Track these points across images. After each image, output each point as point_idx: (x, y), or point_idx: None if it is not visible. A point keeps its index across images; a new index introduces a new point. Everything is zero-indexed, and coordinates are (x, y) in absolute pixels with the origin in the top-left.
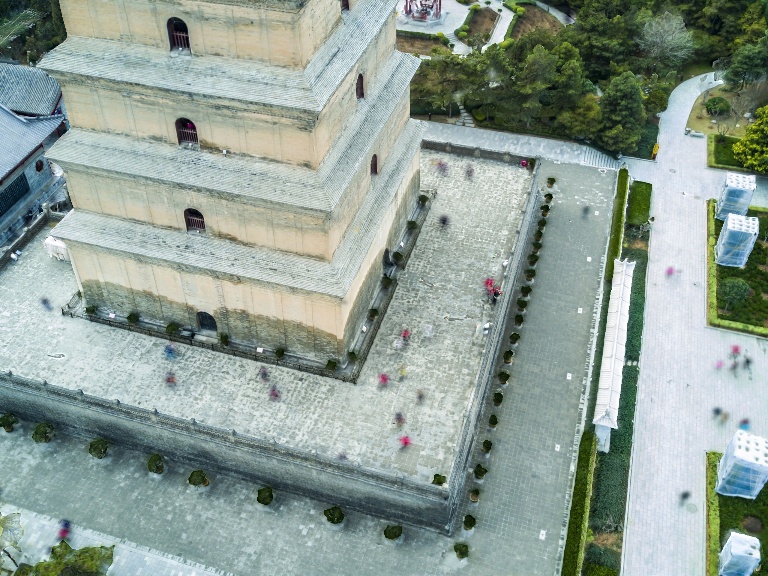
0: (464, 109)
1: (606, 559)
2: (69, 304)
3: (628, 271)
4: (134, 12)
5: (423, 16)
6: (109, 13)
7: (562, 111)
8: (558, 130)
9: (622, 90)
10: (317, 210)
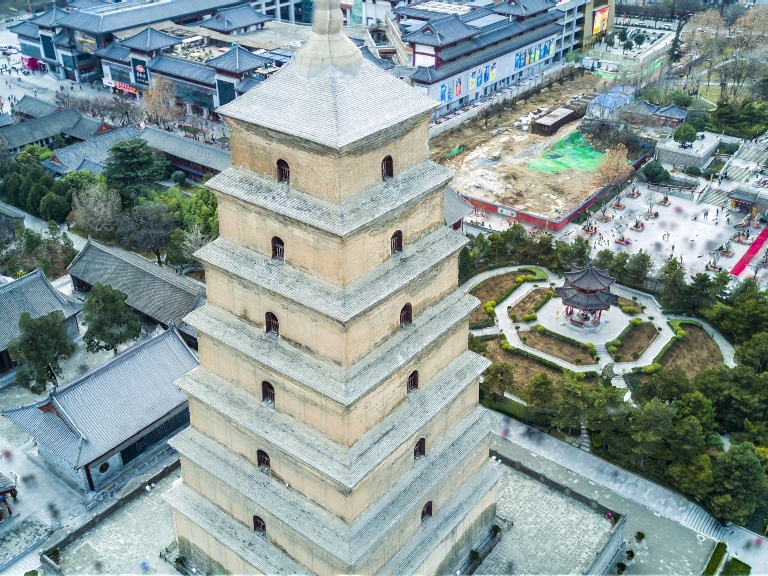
0: (586, 429)
1: None
2: (168, 548)
3: None
4: (242, 368)
5: (580, 322)
6: (227, 363)
7: (676, 461)
8: (669, 479)
9: (738, 460)
10: (341, 559)
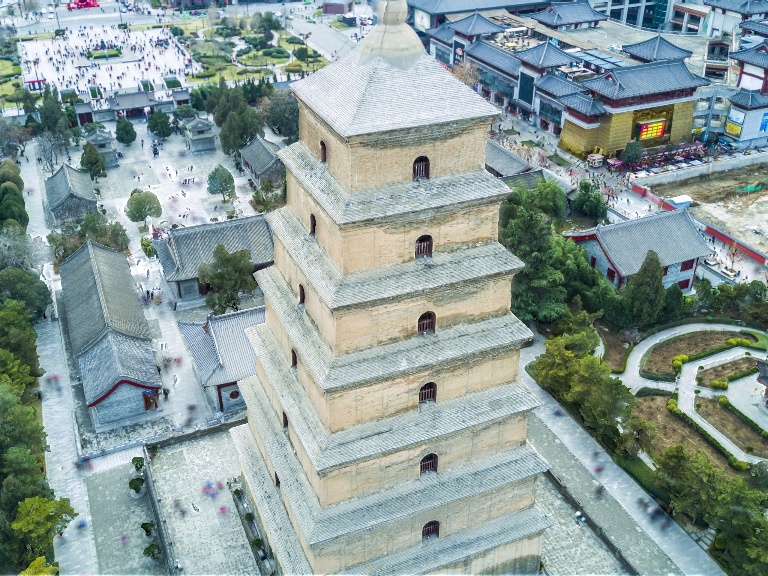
0: None
1: None
2: (237, 478)
3: None
4: None
5: None
6: None
7: None
8: None
9: None
10: None
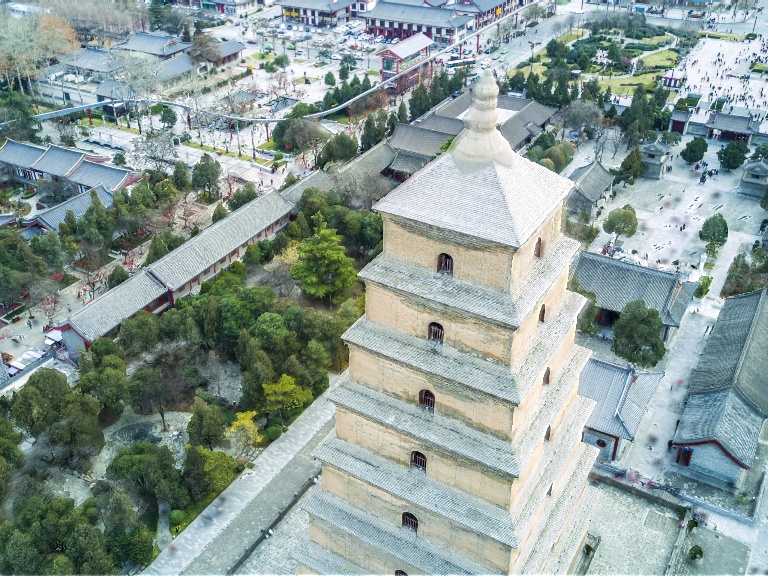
0: None
1: None
2: None
3: None
4: None
5: None
6: None
7: None
8: None
9: None
10: None
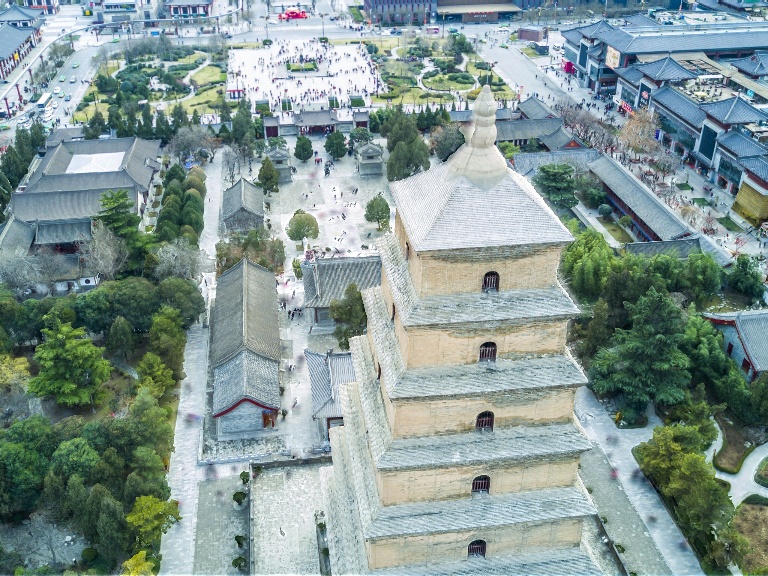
0: None
1: None
2: None
3: None
4: None
5: None
6: None
7: None
8: None
9: None
10: None
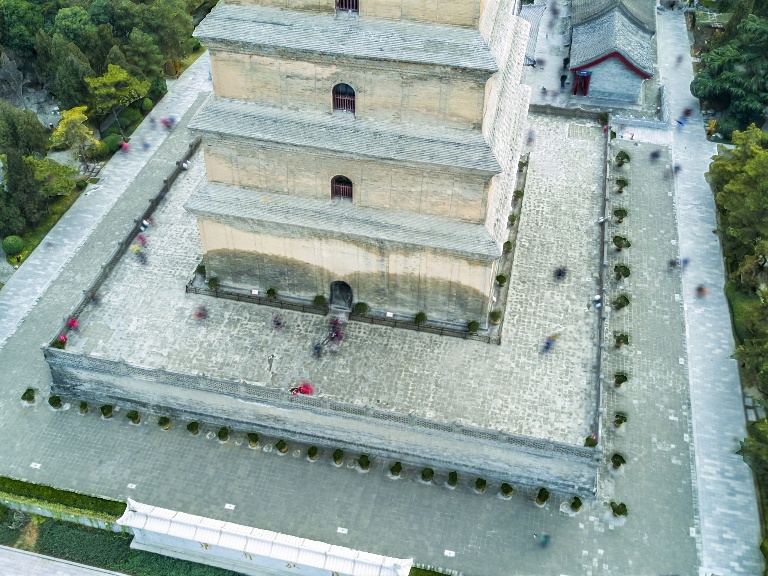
0: None
1: (6, 527)
2: None
3: (388, 574)
4: None
5: None
6: None
7: None
8: None
9: None
10: None
